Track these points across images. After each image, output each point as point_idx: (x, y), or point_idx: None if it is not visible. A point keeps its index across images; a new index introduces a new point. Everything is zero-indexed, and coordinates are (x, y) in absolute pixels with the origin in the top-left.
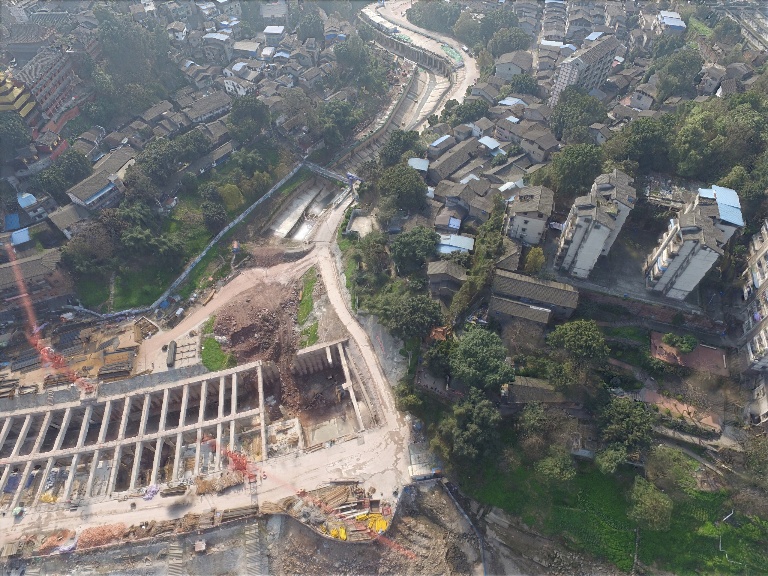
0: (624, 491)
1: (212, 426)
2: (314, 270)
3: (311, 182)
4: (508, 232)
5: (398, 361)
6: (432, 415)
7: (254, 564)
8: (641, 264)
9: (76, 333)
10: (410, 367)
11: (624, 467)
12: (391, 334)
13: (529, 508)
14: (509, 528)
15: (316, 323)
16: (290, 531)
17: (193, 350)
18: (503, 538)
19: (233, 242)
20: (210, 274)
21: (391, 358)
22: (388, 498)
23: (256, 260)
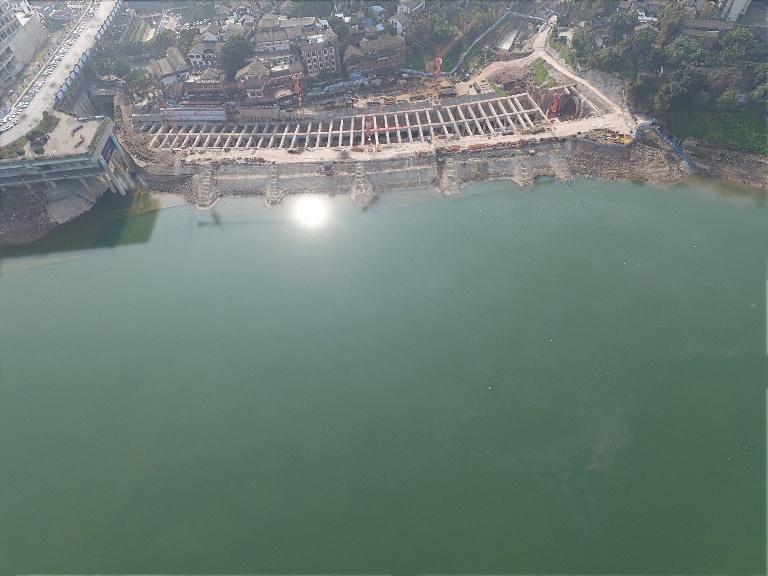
0: (764, 116)
1: (513, 115)
2: (540, 59)
3: (514, 25)
4: (685, 4)
5: (616, 84)
6: (650, 93)
7: (561, 159)
8: (766, 17)
9: (413, 82)
10: (632, 74)
11: (764, 103)
12: (609, 72)
13: (709, 132)
14: (697, 146)
15: (553, 79)
16: (578, 146)
17: (488, 86)
18: (693, 151)
19: (485, 46)
20: (475, 62)
21: (611, 84)
22: (628, 134)
23: (499, 57)
